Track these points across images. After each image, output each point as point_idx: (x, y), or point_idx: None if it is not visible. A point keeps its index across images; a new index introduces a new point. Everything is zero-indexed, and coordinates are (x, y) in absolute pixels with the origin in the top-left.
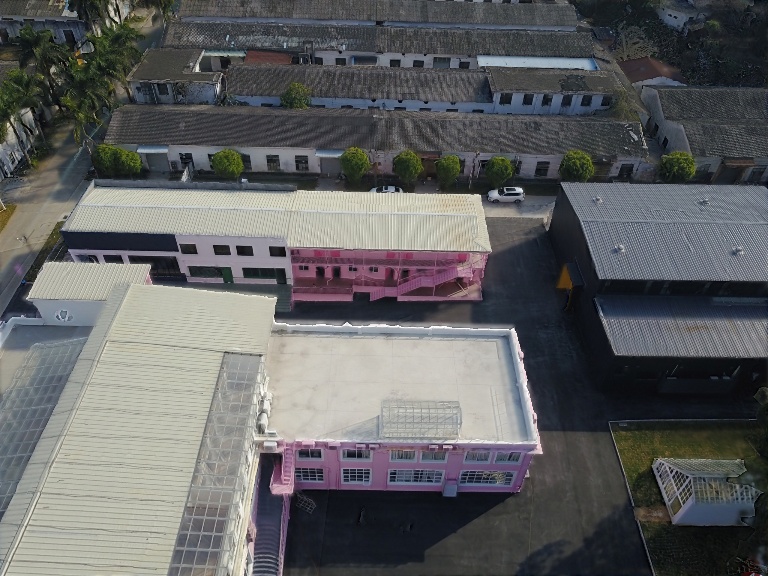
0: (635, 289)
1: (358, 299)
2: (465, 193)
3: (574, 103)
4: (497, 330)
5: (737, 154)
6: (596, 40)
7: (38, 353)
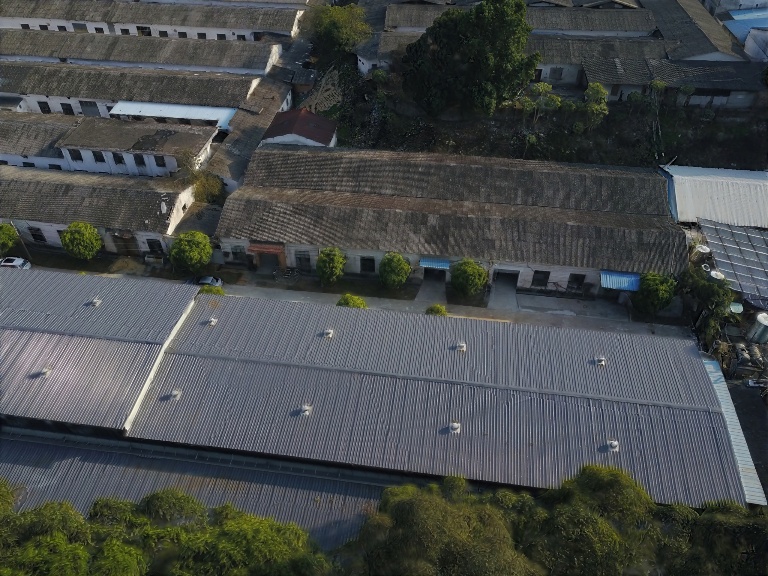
0: None
1: None
2: None
3: (148, 163)
4: None
5: (266, 237)
6: (282, 85)
7: None
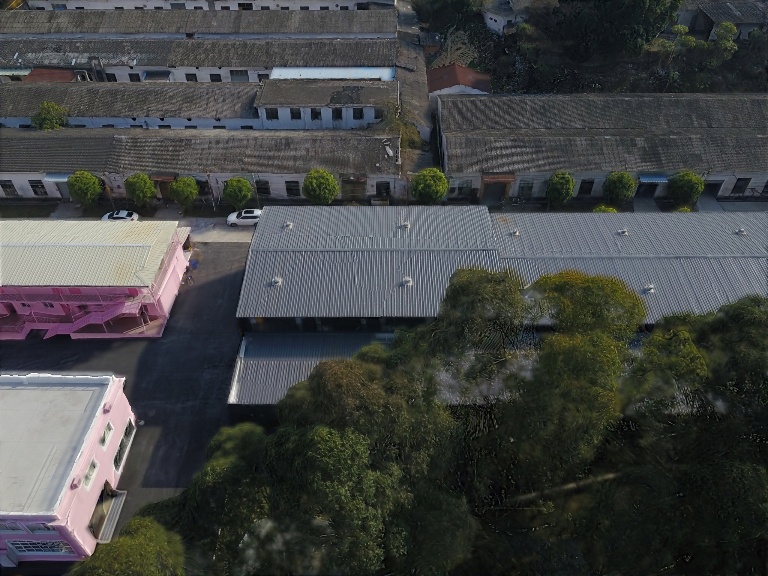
0: (287, 326)
1: (31, 337)
2: (208, 216)
3: (345, 116)
4: (97, 378)
5: (497, 169)
6: (415, 47)
7: None
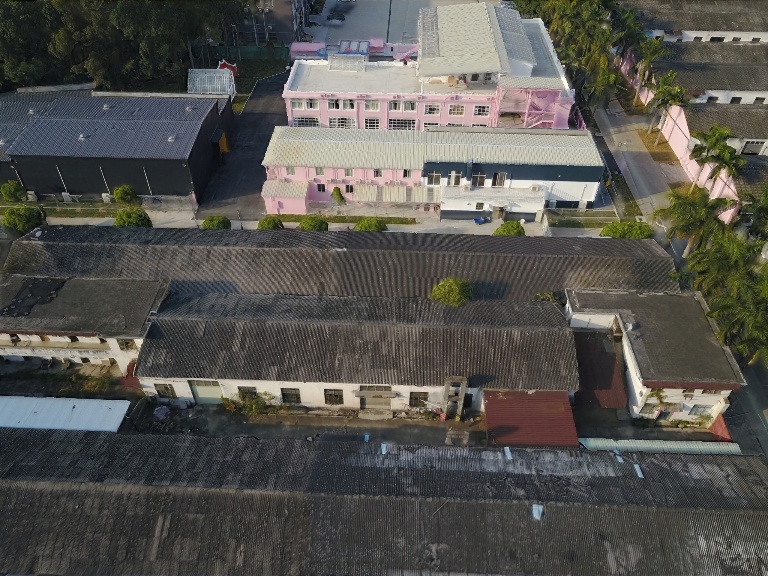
0: None
1: None
2: None
3: None
4: (294, 91)
5: None
6: None
7: (531, 61)
